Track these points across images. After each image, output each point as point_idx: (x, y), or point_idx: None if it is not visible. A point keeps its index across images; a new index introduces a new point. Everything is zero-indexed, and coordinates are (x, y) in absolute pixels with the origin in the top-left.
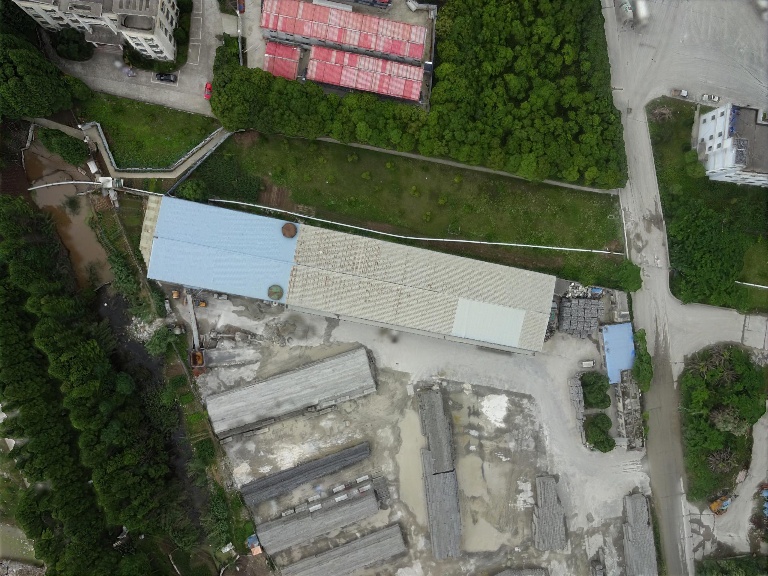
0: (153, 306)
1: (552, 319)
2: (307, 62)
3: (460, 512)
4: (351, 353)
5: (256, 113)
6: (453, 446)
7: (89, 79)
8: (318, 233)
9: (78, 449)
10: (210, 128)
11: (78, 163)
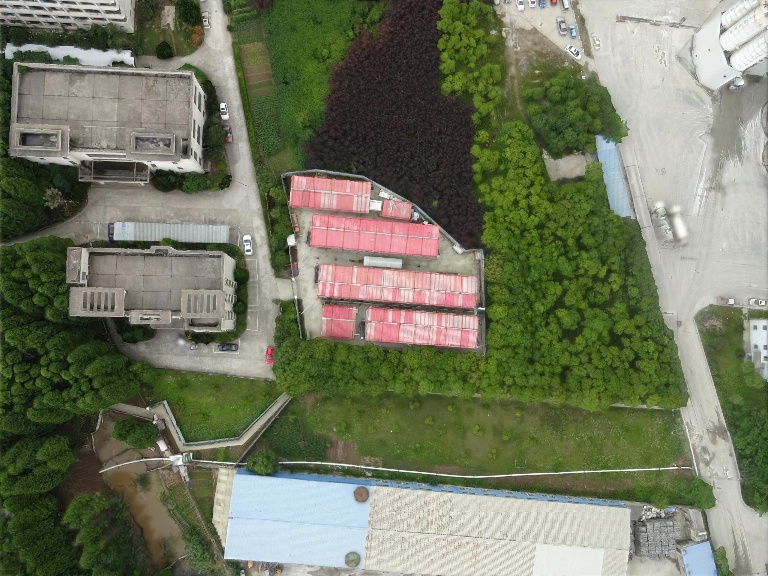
0: None
1: None
2: (362, 315)
3: None
4: None
5: (321, 385)
6: None
7: (153, 357)
8: (390, 493)
9: None
10: (273, 392)
11: None
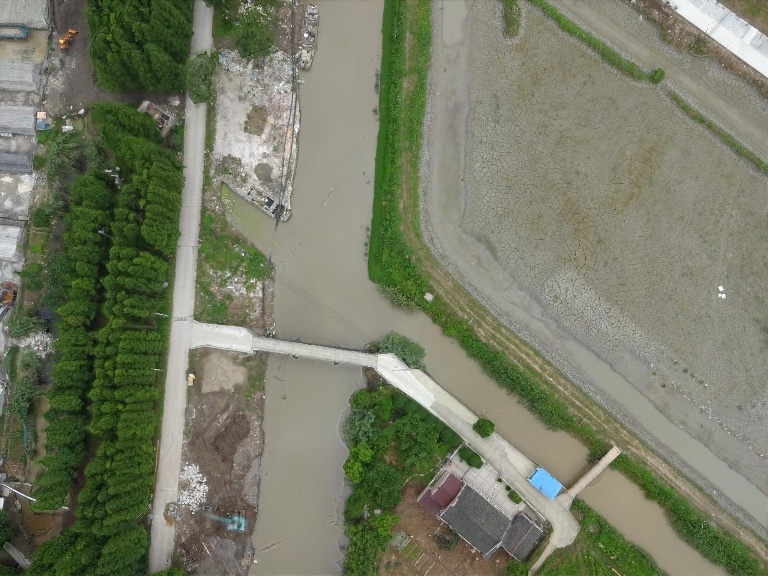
0: (19, 360)
1: None
2: None
3: None
4: None
5: None
6: None
7: None
8: None
9: None
10: None
11: None
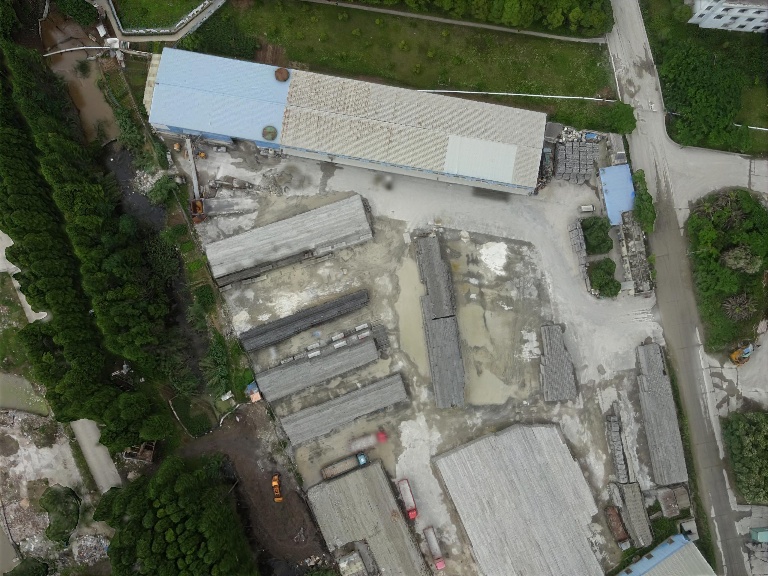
0: (156, 158)
1: (547, 163)
2: None
3: (463, 363)
4: (346, 199)
5: None
6: (452, 292)
7: None
8: (310, 77)
9: (82, 288)
10: None
11: (88, 27)
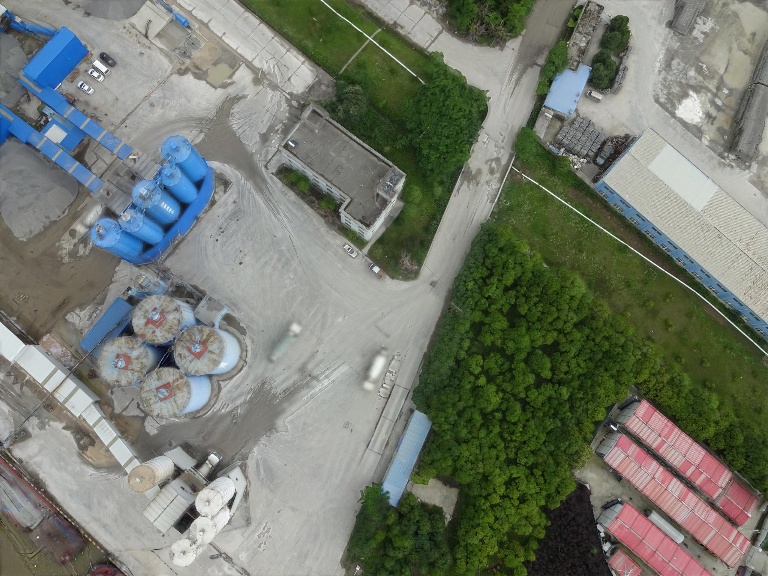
0: None
1: (610, 150)
2: None
3: (762, 49)
4: None
5: None
6: (745, 102)
7: None
8: None
9: None
10: None
11: None
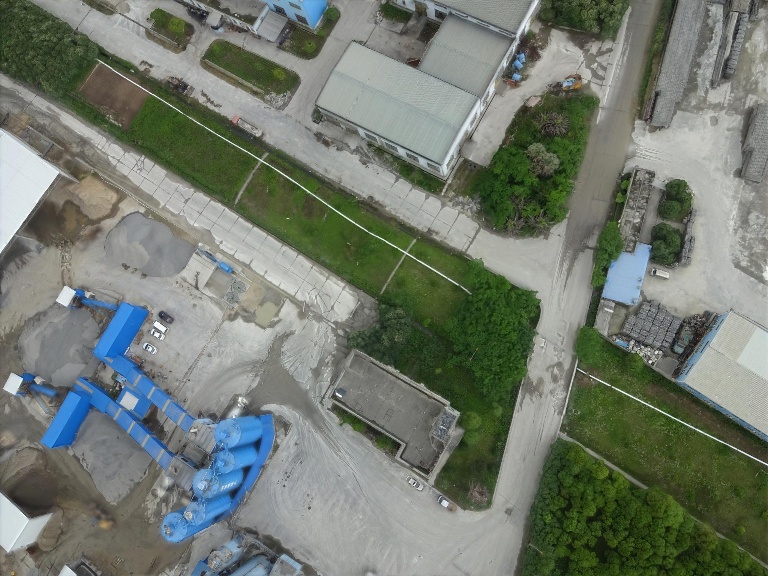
0: None
1: (688, 336)
2: None
3: None
4: None
5: None
6: None
7: None
8: None
9: None
10: None
11: None
